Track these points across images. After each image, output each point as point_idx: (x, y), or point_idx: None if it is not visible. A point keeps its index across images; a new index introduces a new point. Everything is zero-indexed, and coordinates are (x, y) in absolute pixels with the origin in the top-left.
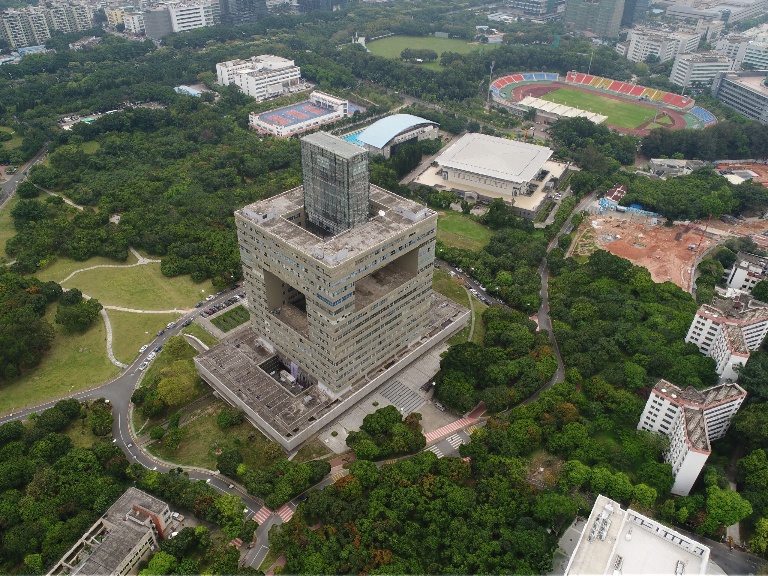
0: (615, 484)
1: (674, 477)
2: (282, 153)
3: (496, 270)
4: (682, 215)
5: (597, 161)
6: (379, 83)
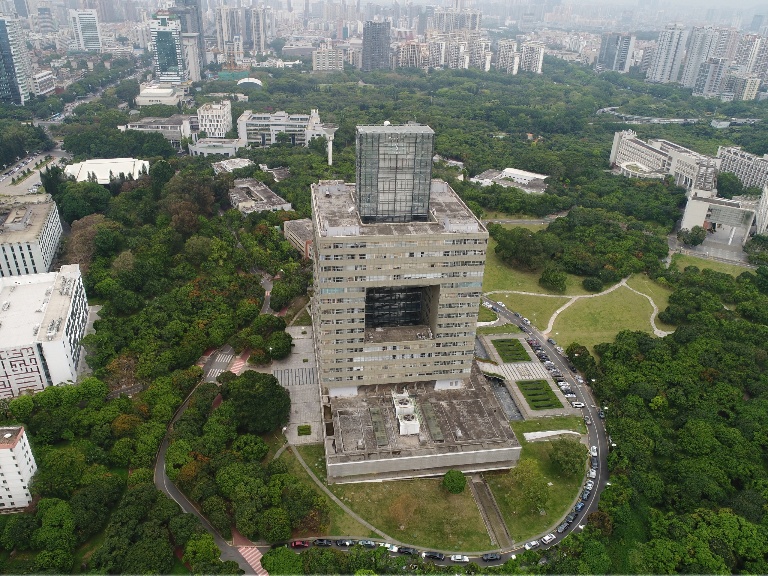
0: None
1: None
2: None
3: None
4: None
5: None
6: None
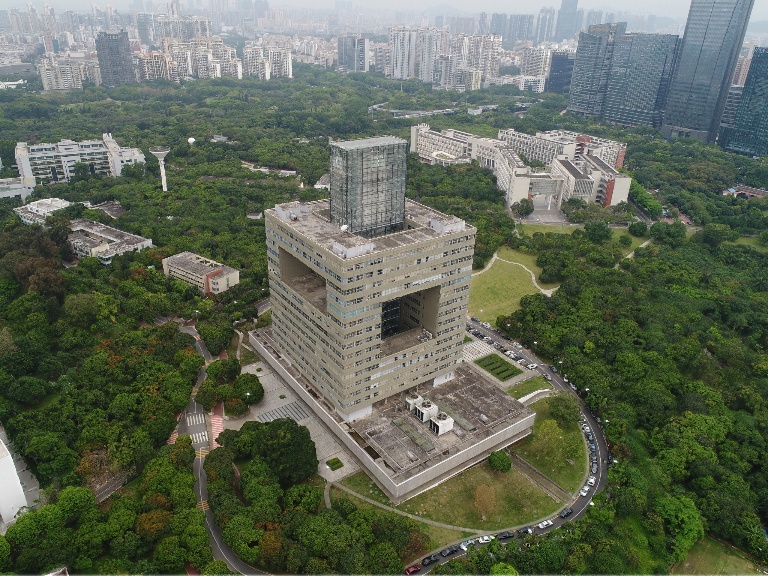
0: None
1: None
2: None
3: None
4: None
5: None
6: None
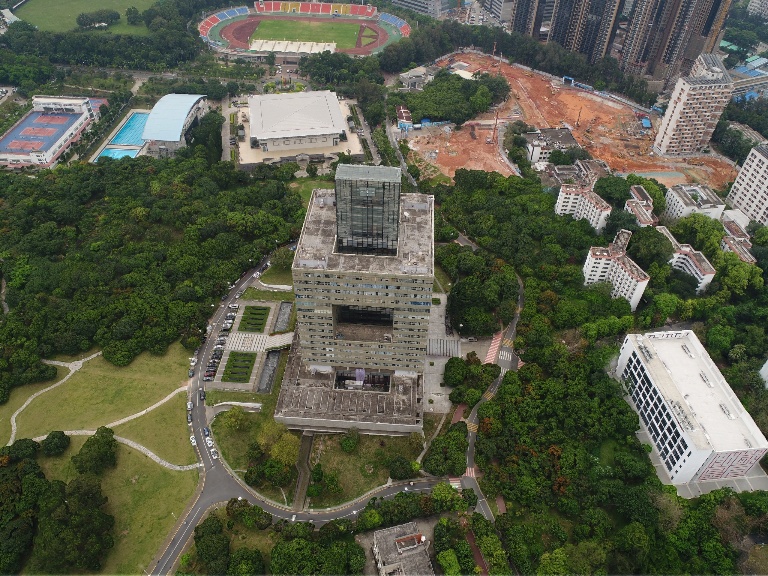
0: (615, 325)
1: (629, 303)
2: (77, 183)
3: None
4: (467, 118)
5: (374, 91)
6: (90, 65)
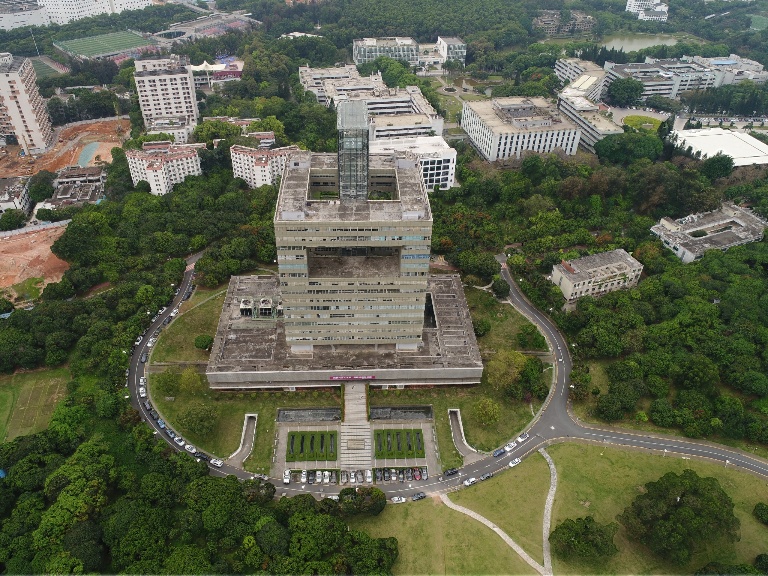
0: None
1: None
2: None
3: (115, 320)
4: None
5: None
6: None
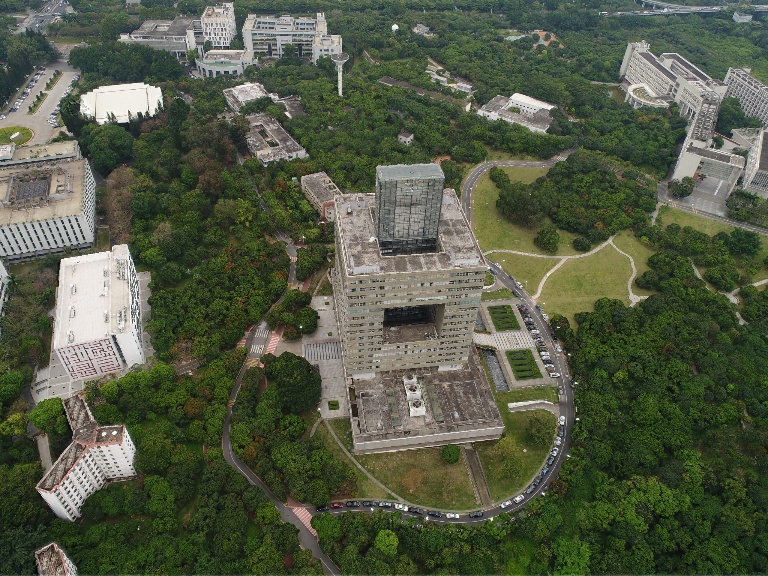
0: (130, 372)
1: None
2: None
3: None
4: None
5: None
6: None
